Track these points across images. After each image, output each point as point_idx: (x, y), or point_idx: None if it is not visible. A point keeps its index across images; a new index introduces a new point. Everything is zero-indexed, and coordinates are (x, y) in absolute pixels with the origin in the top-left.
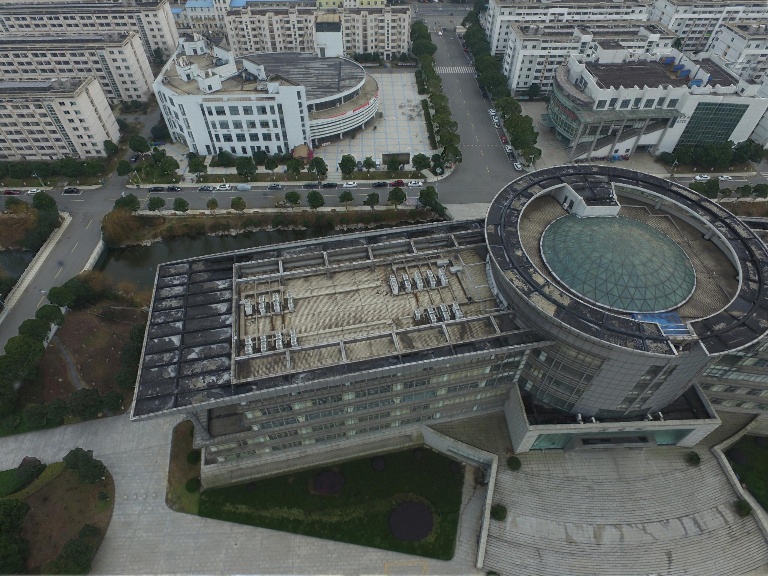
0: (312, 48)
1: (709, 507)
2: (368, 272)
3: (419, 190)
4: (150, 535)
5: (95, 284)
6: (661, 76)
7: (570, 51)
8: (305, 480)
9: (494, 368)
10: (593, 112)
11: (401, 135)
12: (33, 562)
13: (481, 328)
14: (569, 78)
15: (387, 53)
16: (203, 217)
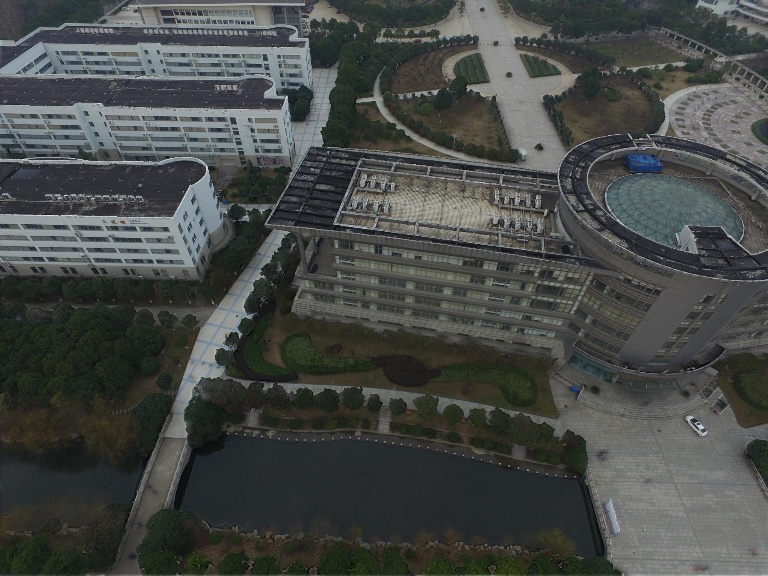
0: None
1: None
2: None
3: None
4: None
5: None
6: None
7: None
8: None
9: None
10: None
11: None
12: None
13: None
14: None
15: None
16: None
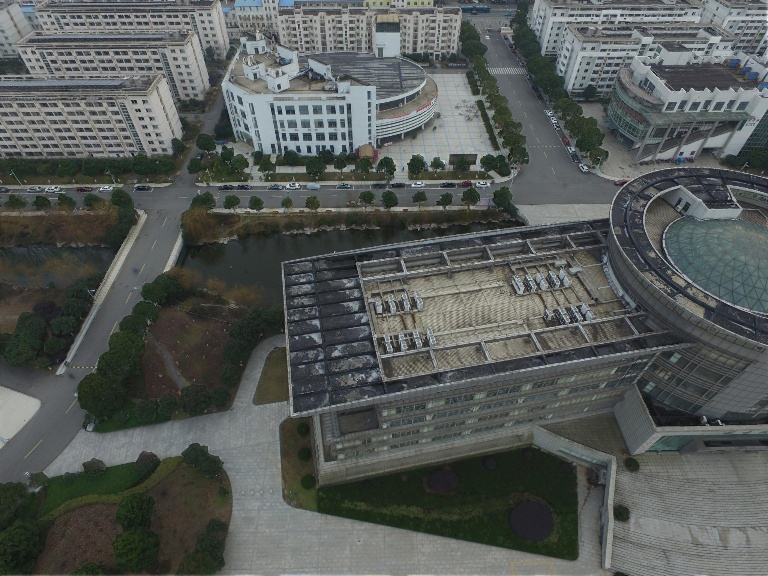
0: (370, 48)
1: None
2: (487, 272)
3: (488, 191)
4: (273, 531)
5: (185, 281)
6: (728, 79)
7: (629, 53)
8: (419, 478)
9: (620, 369)
10: (662, 114)
11: (461, 136)
12: (162, 555)
13: (613, 329)
14: (632, 80)
15: (437, 53)
16: (277, 216)
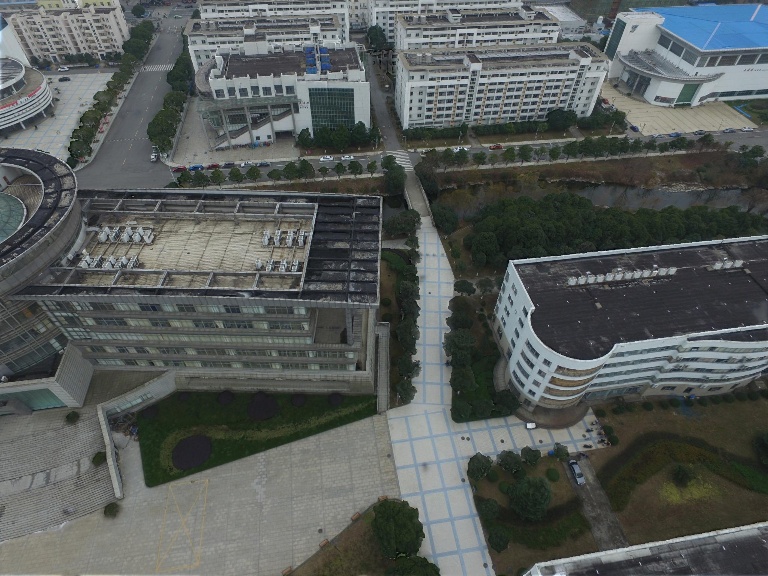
0: None
1: (71, 461)
2: None
3: None
4: None
5: None
6: (293, 65)
7: (239, 45)
8: None
9: None
10: (213, 101)
11: (61, 133)
12: None
13: None
14: None
15: (101, 53)
16: None
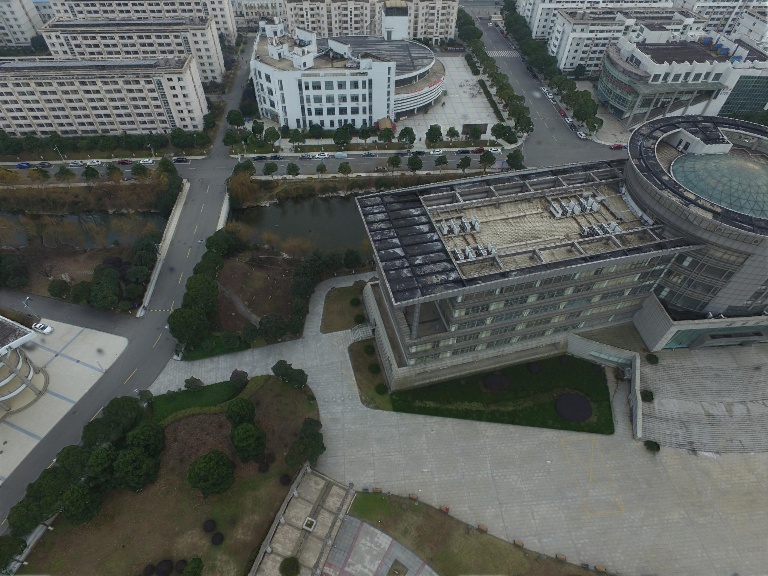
0: (379, 31)
1: None
2: (527, 203)
3: (499, 156)
4: (357, 427)
5: (242, 235)
6: (703, 54)
7: (614, 34)
8: (476, 382)
9: (643, 276)
10: (649, 85)
11: (468, 110)
12: (266, 450)
13: (637, 240)
14: None
15: (436, 39)
16: (312, 181)
